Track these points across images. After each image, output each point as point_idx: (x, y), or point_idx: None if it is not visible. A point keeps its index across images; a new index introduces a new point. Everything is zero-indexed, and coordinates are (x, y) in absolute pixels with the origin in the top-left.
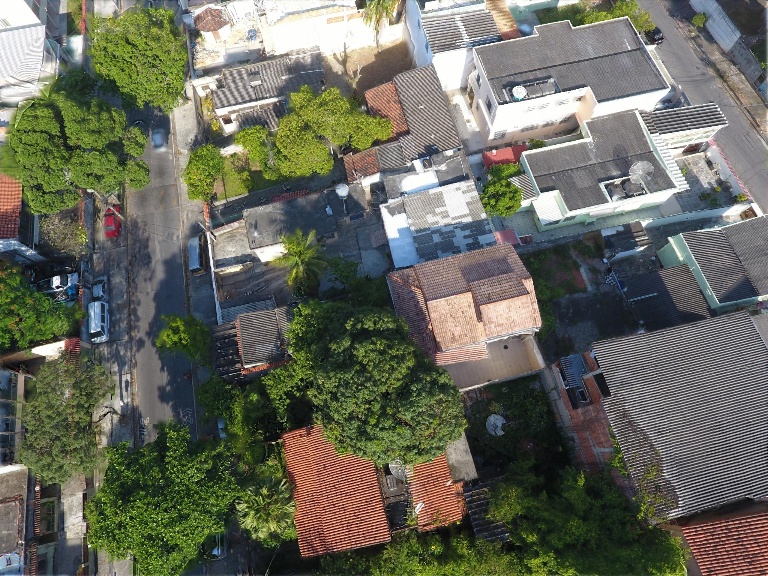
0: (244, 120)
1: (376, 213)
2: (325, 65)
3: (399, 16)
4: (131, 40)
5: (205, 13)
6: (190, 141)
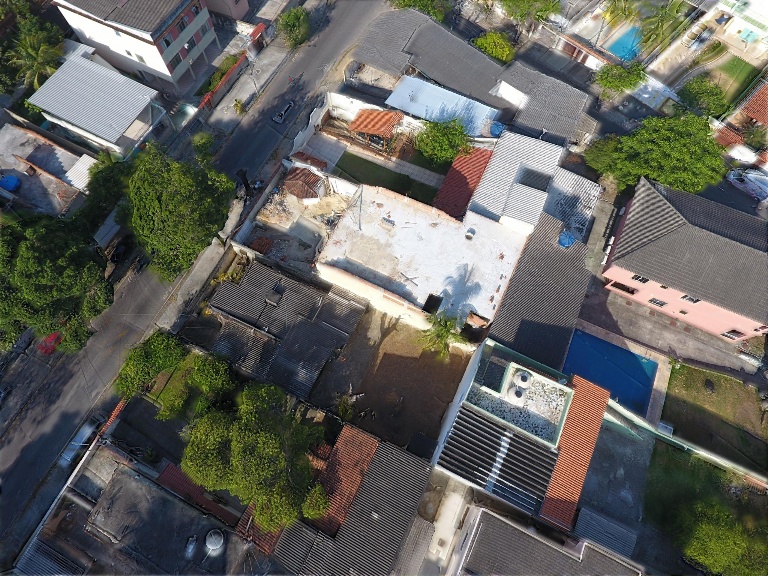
0: (230, 333)
1: (247, 575)
2: (366, 319)
3: (476, 336)
4: (163, 199)
5: (302, 172)
6: (194, 292)
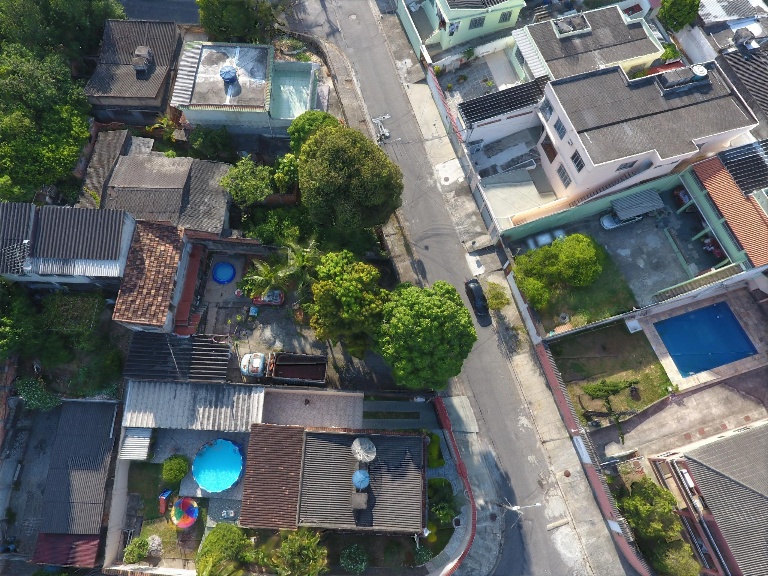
0: None
1: None
2: None
3: None
4: None
5: None
6: None
